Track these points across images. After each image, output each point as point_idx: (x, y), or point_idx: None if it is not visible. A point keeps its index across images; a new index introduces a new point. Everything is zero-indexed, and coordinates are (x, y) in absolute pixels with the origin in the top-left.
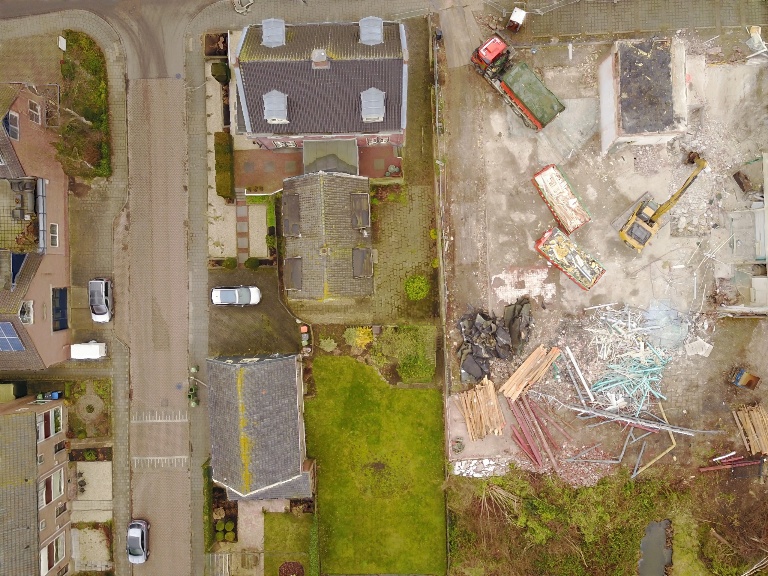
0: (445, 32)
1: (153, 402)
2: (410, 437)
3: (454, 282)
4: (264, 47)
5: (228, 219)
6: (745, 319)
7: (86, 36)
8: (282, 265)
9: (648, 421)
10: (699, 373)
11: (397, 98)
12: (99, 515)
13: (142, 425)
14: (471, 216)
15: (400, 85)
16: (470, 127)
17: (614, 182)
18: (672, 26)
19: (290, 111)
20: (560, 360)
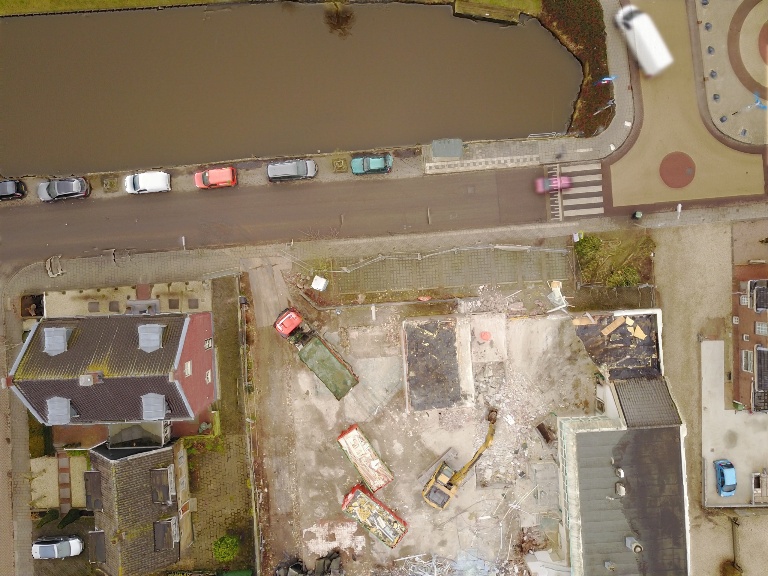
0: (254, 291)
1: None
2: None
3: (270, 531)
4: (45, 356)
5: (50, 471)
6: None
7: None
8: None
9: None
10: None
11: (178, 398)
12: None
13: None
14: (283, 469)
15: (177, 391)
16: (279, 385)
17: (419, 437)
18: (475, 282)
19: (78, 408)
20: None
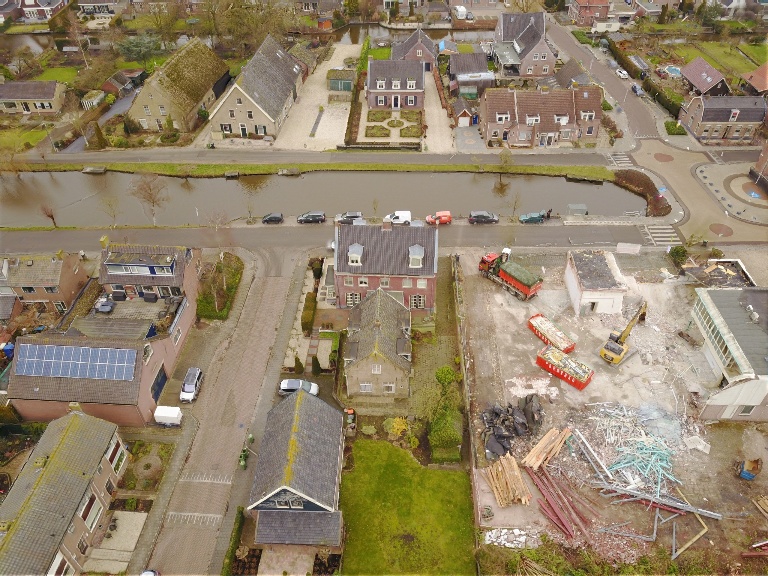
0: (462, 262)
1: (205, 466)
2: (440, 513)
3: (475, 388)
4: None
5: (303, 346)
6: (730, 427)
7: (236, 256)
8: (338, 375)
9: (670, 501)
10: (706, 467)
11: (432, 252)
12: (113, 566)
13: (188, 484)
14: (486, 348)
15: (434, 243)
16: (481, 301)
17: (589, 331)
18: None
19: (364, 258)
20: (573, 440)
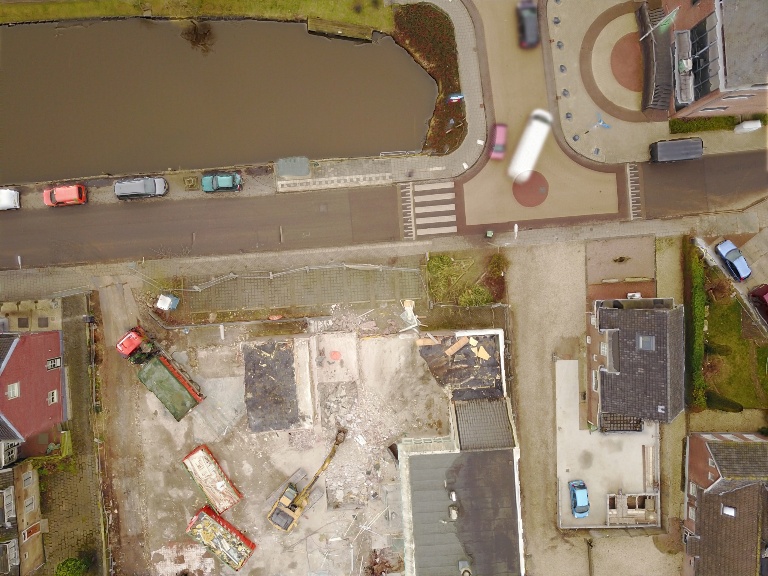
0: (104, 310)
1: None
2: None
3: (121, 553)
4: None
5: None
6: None
7: None
8: None
9: None
10: None
11: (1, 421)
12: None
13: None
14: (133, 490)
15: None
16: (127, 405)
17: (269, 458)
18: (328, 300)
19: None
20: None
